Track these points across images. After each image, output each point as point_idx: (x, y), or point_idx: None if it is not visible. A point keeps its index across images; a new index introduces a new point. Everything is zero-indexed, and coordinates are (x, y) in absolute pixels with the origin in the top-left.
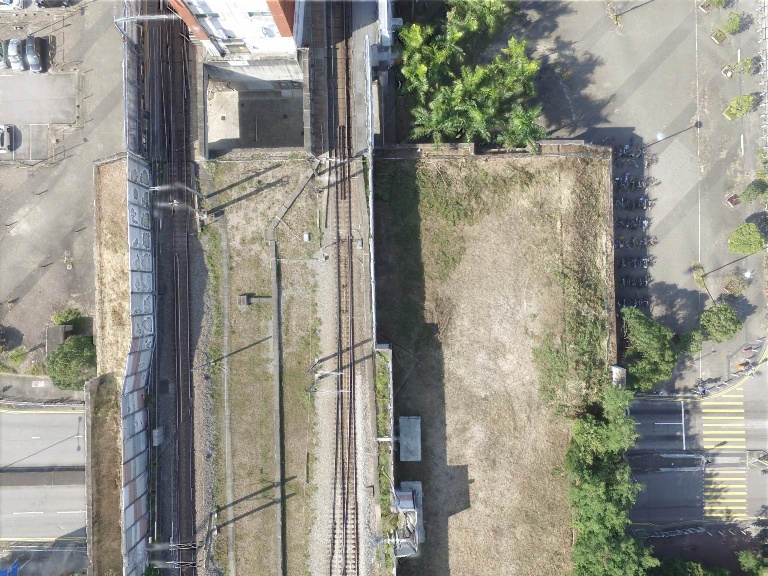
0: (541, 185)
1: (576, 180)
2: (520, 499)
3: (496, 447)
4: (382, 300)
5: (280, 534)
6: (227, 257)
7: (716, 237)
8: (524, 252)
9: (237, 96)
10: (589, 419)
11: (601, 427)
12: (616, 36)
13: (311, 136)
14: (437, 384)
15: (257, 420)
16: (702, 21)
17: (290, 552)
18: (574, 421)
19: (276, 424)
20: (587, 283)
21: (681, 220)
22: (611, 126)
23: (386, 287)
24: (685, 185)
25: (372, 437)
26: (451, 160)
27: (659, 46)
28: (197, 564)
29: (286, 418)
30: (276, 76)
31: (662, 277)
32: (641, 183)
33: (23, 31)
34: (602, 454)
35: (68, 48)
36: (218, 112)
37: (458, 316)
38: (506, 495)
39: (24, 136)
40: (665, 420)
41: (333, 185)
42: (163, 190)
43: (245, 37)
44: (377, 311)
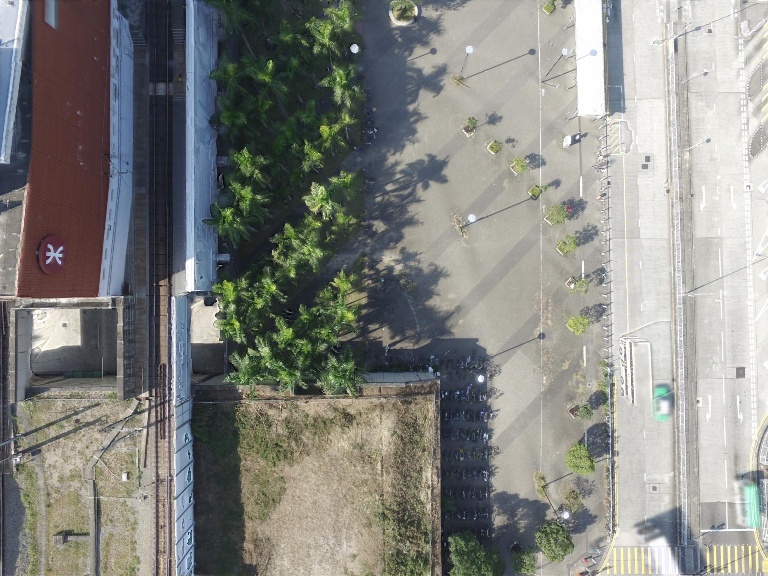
0: (362, 426)
1: (397, 421)
2: None
3: None
4: (201, 539)
5: None
6: (45, 495)
7: (558, 447)
8: (344, 493)
9: None
10: None
11: None
12: (461, 247)
13: (127, 381)
14: None
15: None
16: (547, 233)
17: None
18: None
19: None
20: (409, 520)
21: (523, 431)
22: (455, 337)
23: (206, 526)
24: (527, 396)
25: None
26: (272, 401)
27: (504, 257)
28: None
29: None
30: None
31: (504, 487)
32: (482, 397)
33: None
34: None
35: None
36: (58, 321)
37: (278, 556)
38: None
39: None
40: None
41: (153, 424)
42: None
43: None
44: (196, 551)
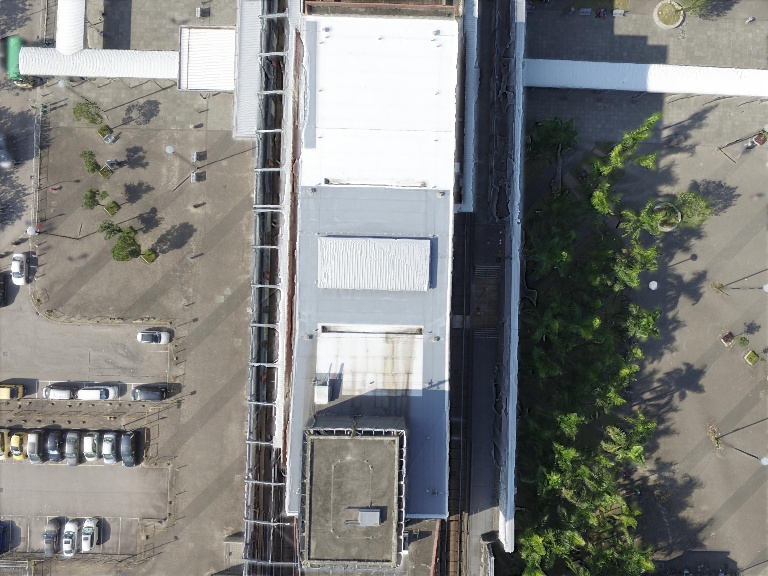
0: None
1: None
2: None
3: None
4: None
5: None
6: None
7: None
8: None
9: None
10: None
11: None
12: (716, 459)
13: None
14: None
15: None
16: None
17: None
18: None
19: None
20: None
21: None
22: (707, 550)
23: None
24: None
25: None
26: None
27: (758, 470)
28: None
29: None
30: None
31: None
32: None
33: (117, 421)
34: None
35: (162, 442)
36: None
37: None
38: None
39: (113, 530)
40: None
41: None
42: None
43: None
44: None
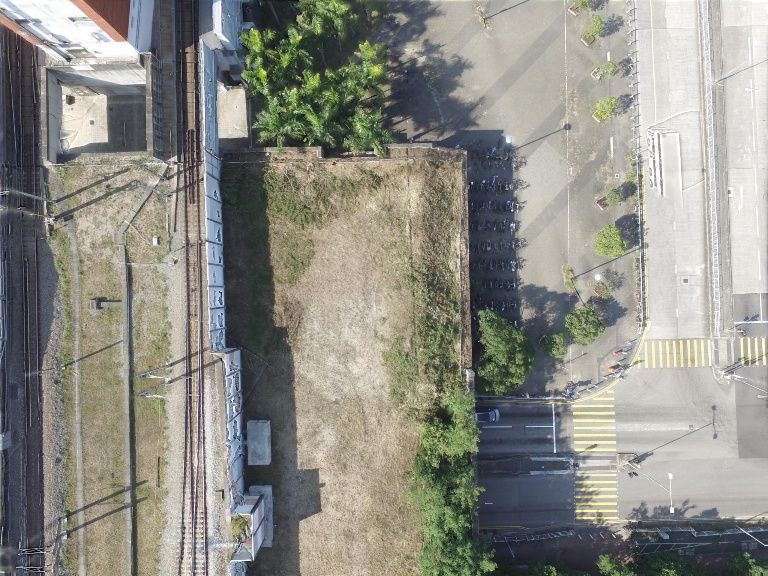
0: (390, 188)
1: (425, 183)
2: (371, 503)
3: (347, 451)
4: (232, 304)
5: (130, 538)
6: (77, 261)
7: (586, 239)
8: (373, 255)
9: (105, 100)
10: (435, 423)
11: (448, 431)
12: (485, 39)
13: (156, 140)
14: (287, 388)
15: (108, 424)
16: (571, 23)
17: (141, 556)
18: (421, 425)
19: (126, 428)
20: (439, 286)
21: (550, 223)
22: (479, 129)
23: (236, 291)
24: (554, 187)
25: (221, 441)
26: (299, 164)
27: (528, 49)
28: (45, 569)
29: (137, 422)
30: (129, 80)
31: (532, 280)
32: (508, 186)
33: None
34: (451, 458)
35: None
36: (85, 116)
37: (308, 320)
38: (357, 499)
39: None
40: (536, 423)
41: (182, 189)
42: (12, 195)
43: (81, 42)
44: (227, 315)
